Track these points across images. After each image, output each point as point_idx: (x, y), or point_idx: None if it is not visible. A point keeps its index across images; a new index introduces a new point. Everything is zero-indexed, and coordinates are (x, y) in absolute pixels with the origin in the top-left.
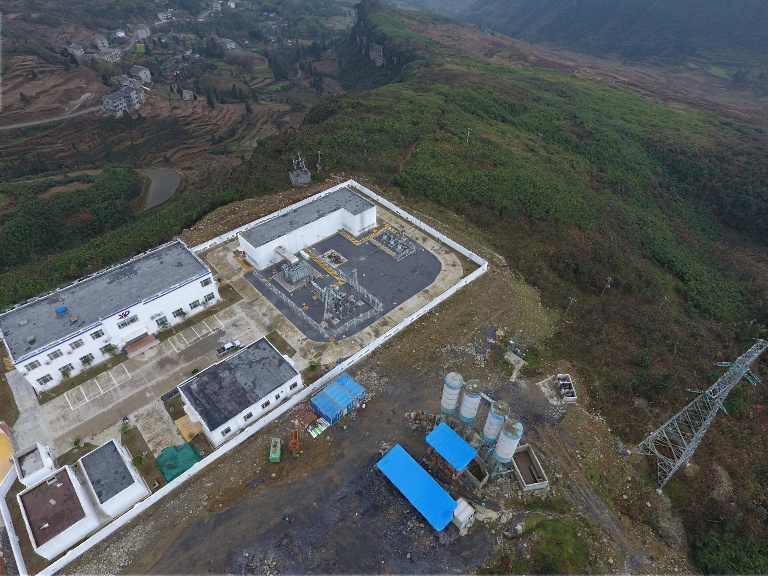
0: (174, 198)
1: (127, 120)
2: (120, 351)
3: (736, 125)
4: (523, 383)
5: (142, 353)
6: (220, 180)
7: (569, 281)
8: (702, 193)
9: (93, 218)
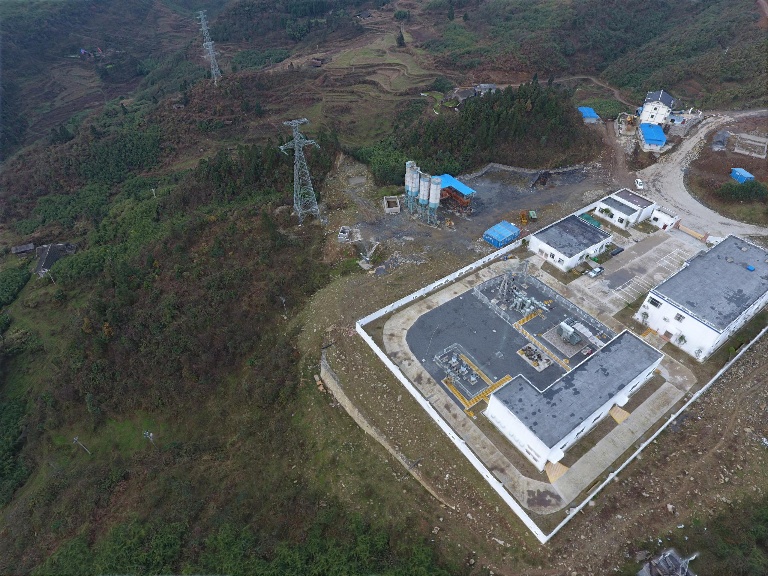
0: None
1: None
2: None
3: None
4: (372, 239)
5: None
6: None
7: None
8: None
9: None
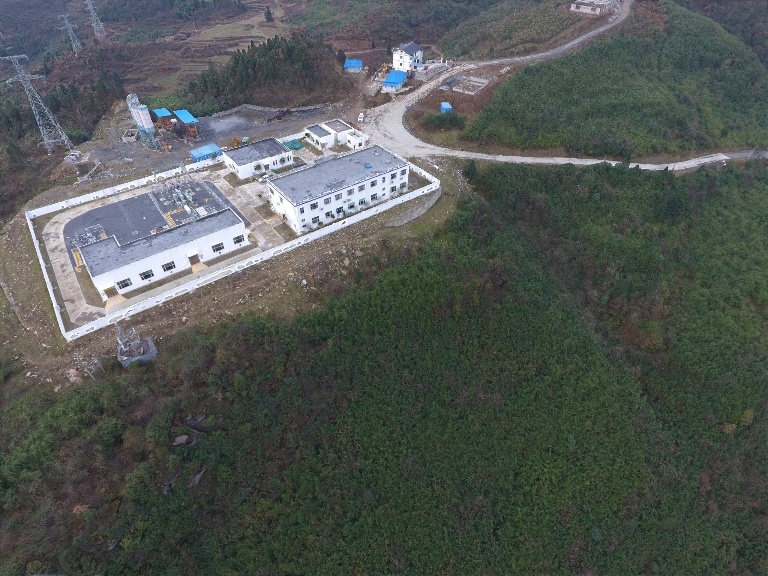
0: None
1: None
2: None
3: None
4: (95, 161)
5: None
6: None
7: None
8: None
9: None
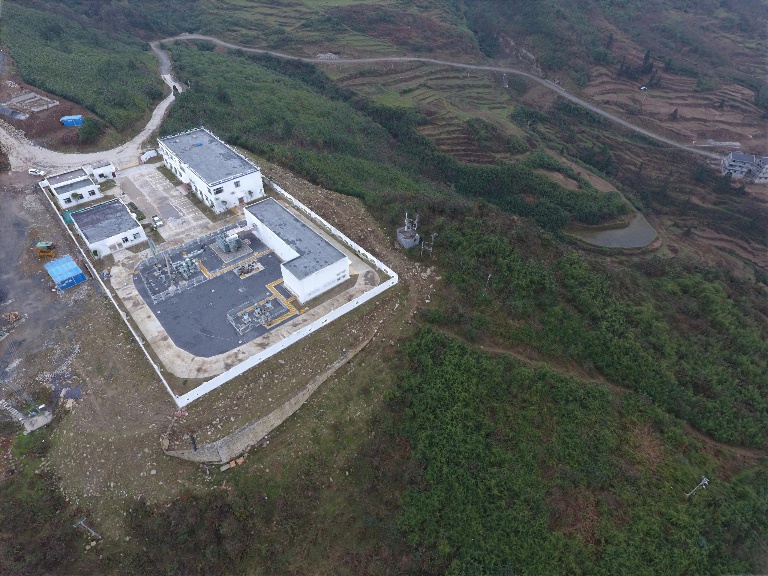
0: (604, 250)
1: (722, 182)
2: None
3: None
4: None
5: (178, 190)
6: None
7: None
8: None
9: (531, 205)
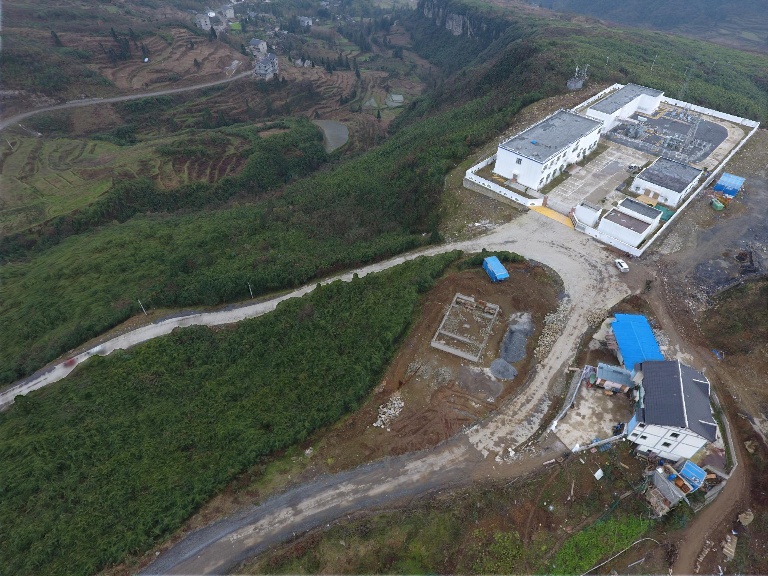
0: (350, 142)
1: (276, 82)
2: (562, 172)
3: None
4: None
5: (577, 172)
6: (371, 130)
7: None
8: None
9: (304, 155)
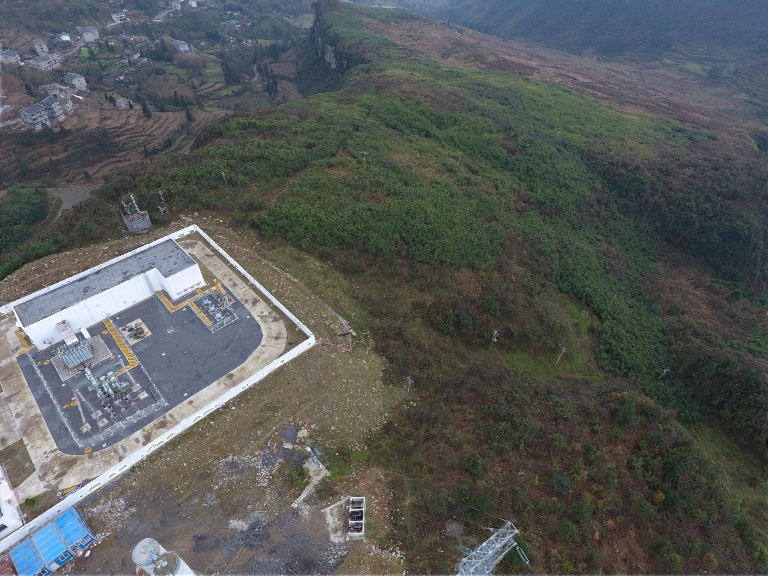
0: None
1: (47, 134)
2: None
3: (689, 132)
4: (306, 510)
5: None
6: None
7: (449, 335)
8: (644, 209)
9: None
